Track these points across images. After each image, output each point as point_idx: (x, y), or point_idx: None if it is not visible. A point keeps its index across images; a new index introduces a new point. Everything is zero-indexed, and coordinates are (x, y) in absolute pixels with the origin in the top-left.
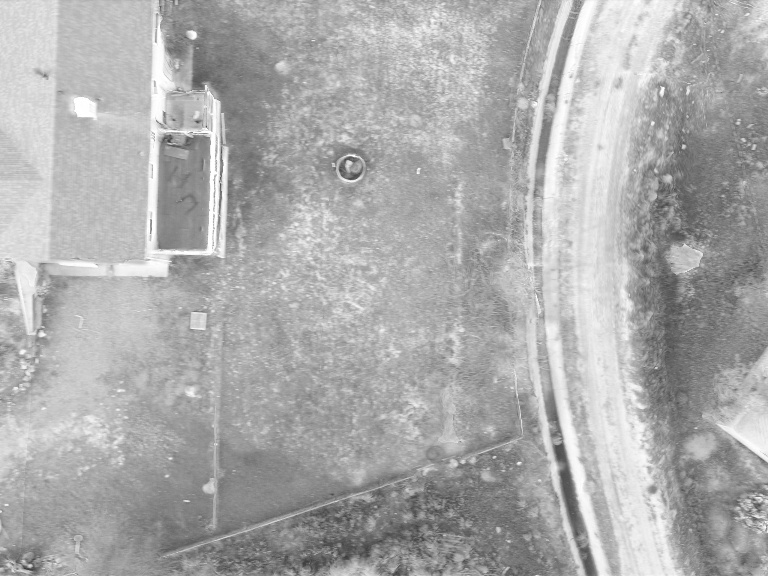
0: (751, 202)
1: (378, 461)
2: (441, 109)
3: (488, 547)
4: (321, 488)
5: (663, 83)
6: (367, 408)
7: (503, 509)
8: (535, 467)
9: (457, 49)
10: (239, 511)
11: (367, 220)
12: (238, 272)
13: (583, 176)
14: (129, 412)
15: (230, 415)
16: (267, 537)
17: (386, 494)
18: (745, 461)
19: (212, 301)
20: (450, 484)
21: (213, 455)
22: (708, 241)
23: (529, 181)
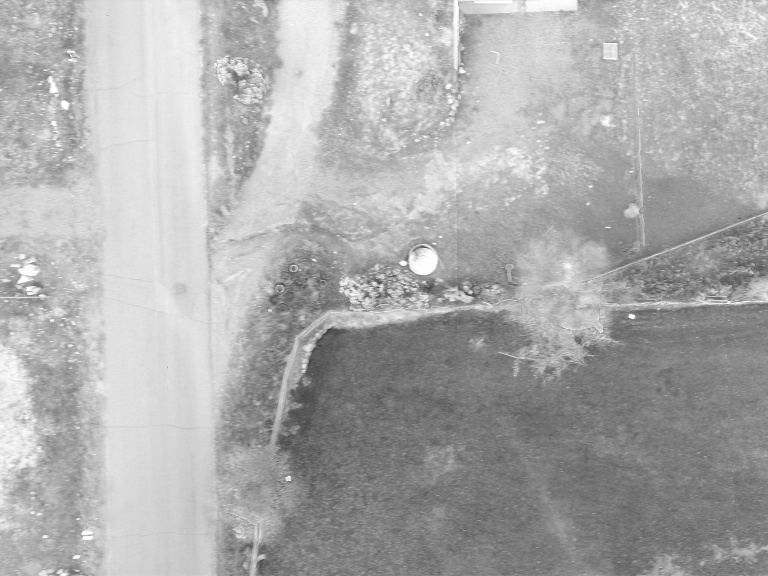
0: None
1: None
2: None
3: None
4: (730, 212)
5: None
6: (766, 134)
7: None
8: None
9: None
10: (656, 236)
11: None
12: (641, 4)
13: None
14: (550, 142)
15: (643, 143)
16: (683, 261)
17: None
18: None
19: (620, 32)
20: None
21: (638, 176)
22: None
23: None
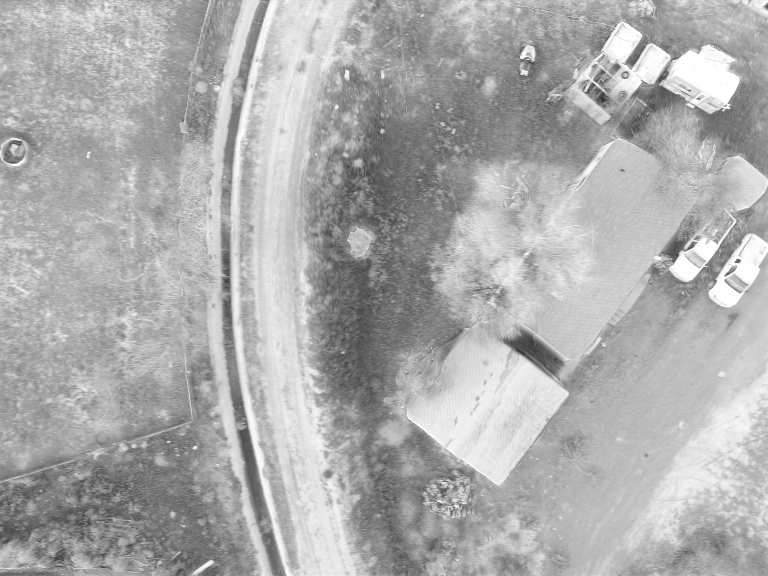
0: (451, 186)
1: (44, 445)
2: (114, 93)
3: (158, 532)
4: None
5: (350, 67)
6: (32, 392)
7: (178, 494)
8: (213, 452)
9: (132, 33)
10: None
11: (33, 204)
12: None
13: (265, 160)
14: None
15: None
16: None
17: (50, 478)
18: (440, 446)
19: None
20: (120, 468)
21: None
22: (403, 225)
23: (213, 165)
